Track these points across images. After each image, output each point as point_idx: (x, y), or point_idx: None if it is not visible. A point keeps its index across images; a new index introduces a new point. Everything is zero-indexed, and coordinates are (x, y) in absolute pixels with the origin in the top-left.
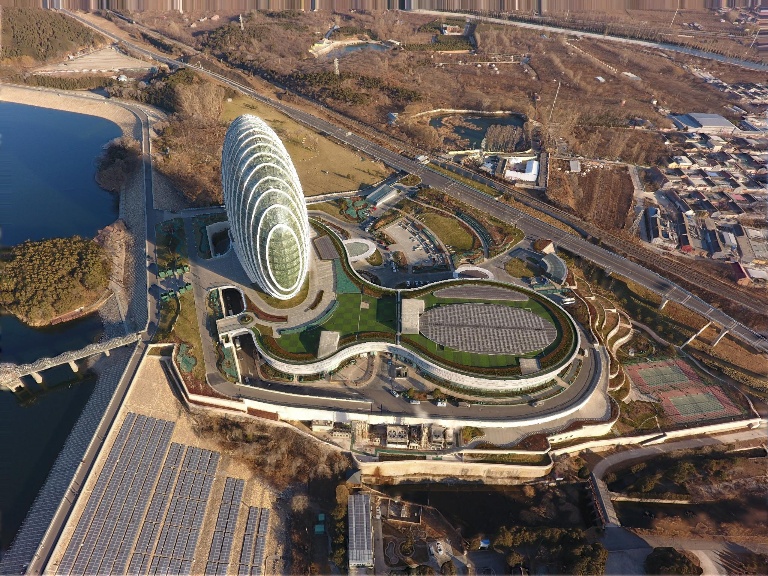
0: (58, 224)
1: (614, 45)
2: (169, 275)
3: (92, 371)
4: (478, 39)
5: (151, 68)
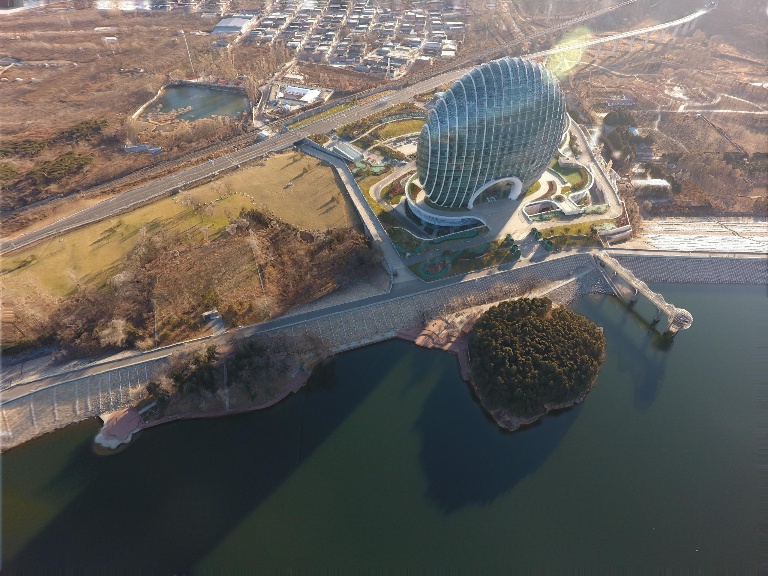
0: (410, 407)
1: (4, 19)
2: None
3: (632, 288)
4: None
5: None
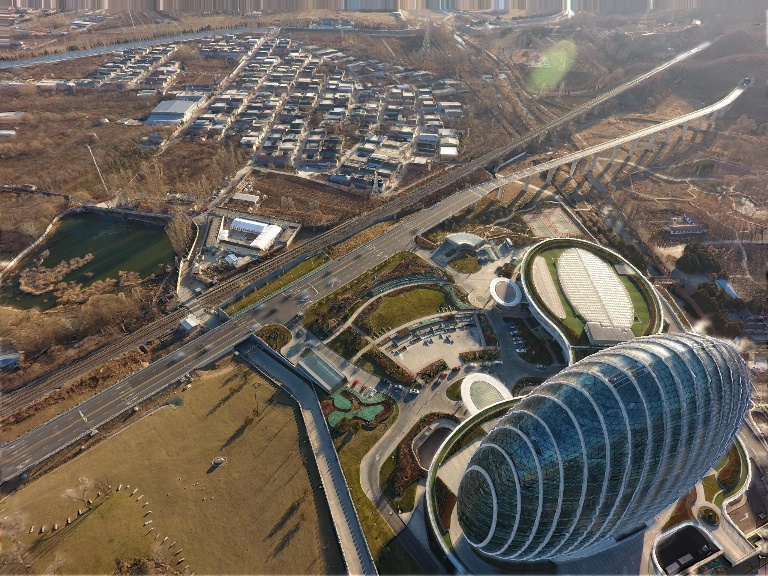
0: None
1: None
2: None
3: None
4: None
5: None
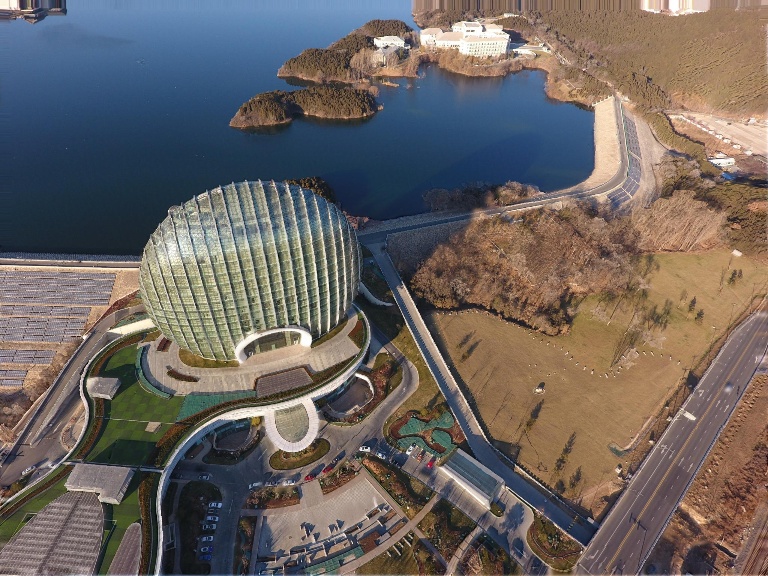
0: (374, 194)
1: None
2: None
3: None
4: None
5: None
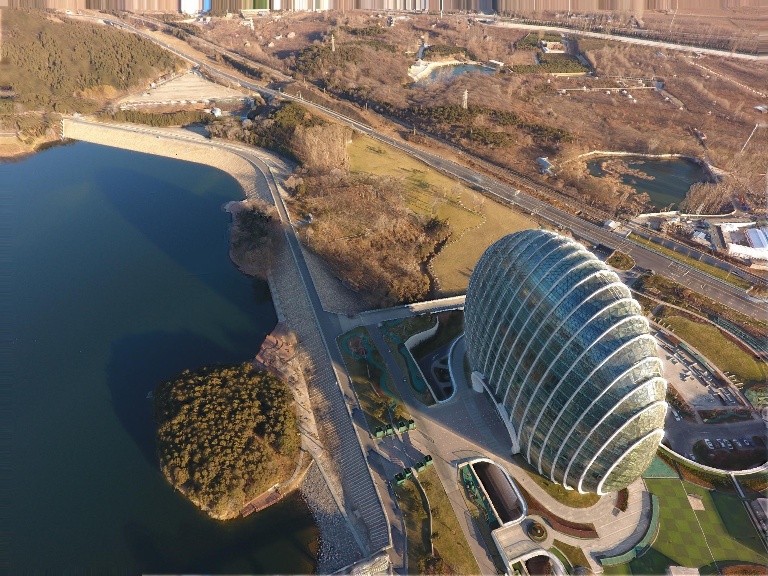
0: (204, 330)
1: (745, 64)
2: (388, 434)
3: None
4: (592, 59)
5: (244, 98)
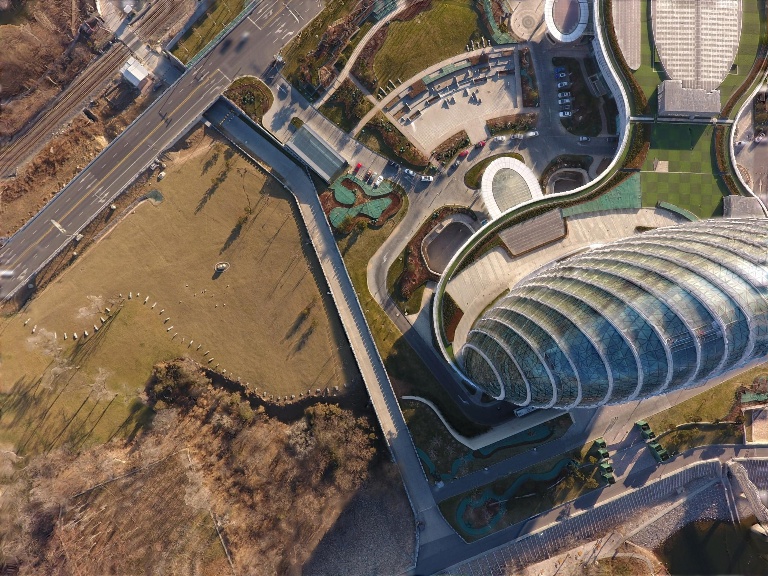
0: None
1: None
2: None
3: None
4: None
5: None
